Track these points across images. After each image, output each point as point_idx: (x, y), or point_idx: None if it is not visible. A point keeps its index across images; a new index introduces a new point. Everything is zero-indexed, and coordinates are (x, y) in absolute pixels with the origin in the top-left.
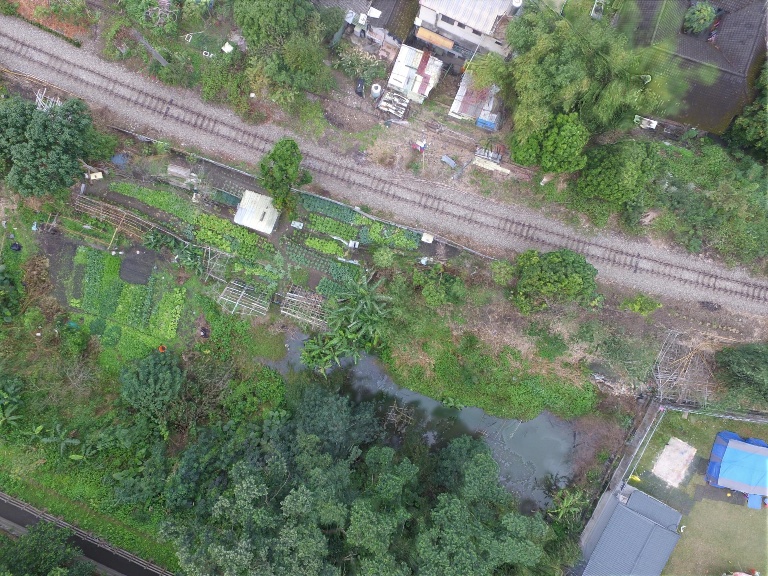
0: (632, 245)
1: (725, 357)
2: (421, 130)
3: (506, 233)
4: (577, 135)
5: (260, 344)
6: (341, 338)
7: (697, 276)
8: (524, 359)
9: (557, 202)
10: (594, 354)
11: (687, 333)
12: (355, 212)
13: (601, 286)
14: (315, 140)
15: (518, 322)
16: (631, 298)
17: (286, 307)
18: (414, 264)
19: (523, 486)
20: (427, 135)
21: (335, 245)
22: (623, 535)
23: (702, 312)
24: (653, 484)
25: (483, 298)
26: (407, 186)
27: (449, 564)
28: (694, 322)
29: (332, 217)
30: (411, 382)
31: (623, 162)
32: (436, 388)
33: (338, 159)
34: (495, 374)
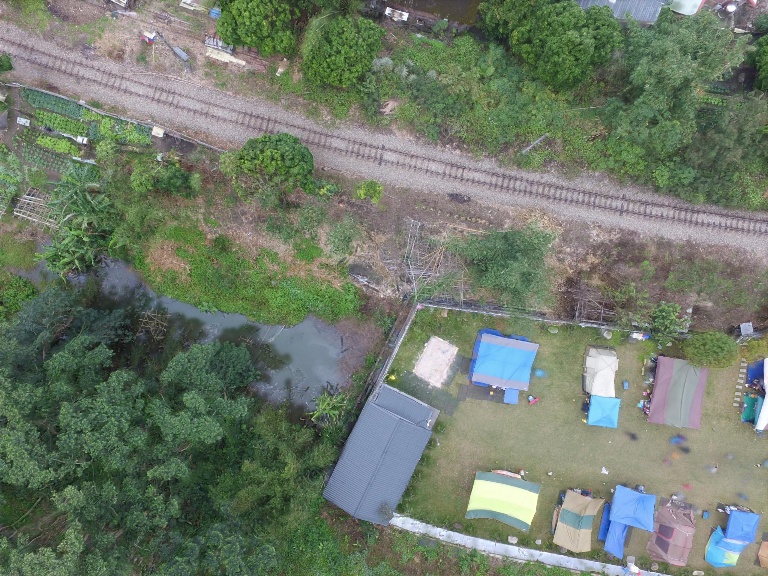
0: (376, 137)
1: (468, 247)
2: (150, 21)
3: (245, 127)
4: (256, 1)
5: (8, 253)
6: (73, 238)
7: (444, 167)
8: (282, 262)
9: (295, 93)
10: (355, 255)
11: (436, 226)
12: (82, 107)
13: (346, 180)
14: (40, 34)
15: (273, 223)
16: None
17: (20, 209)
18: (151, 161)
19: (291, 394)
20: (156, 26)
21: (67, 143)
22: (370, 432)
23: (451, 204)
24: (414, 384)
25: (229, 197)
26: (139, 80)
27: (89, 430)
28: (442, 214)
29: (60, 113)
30: (166, 288)
31: (328, 37)
32: (192, 293)
33: (65, 53)
34: (251, 277)
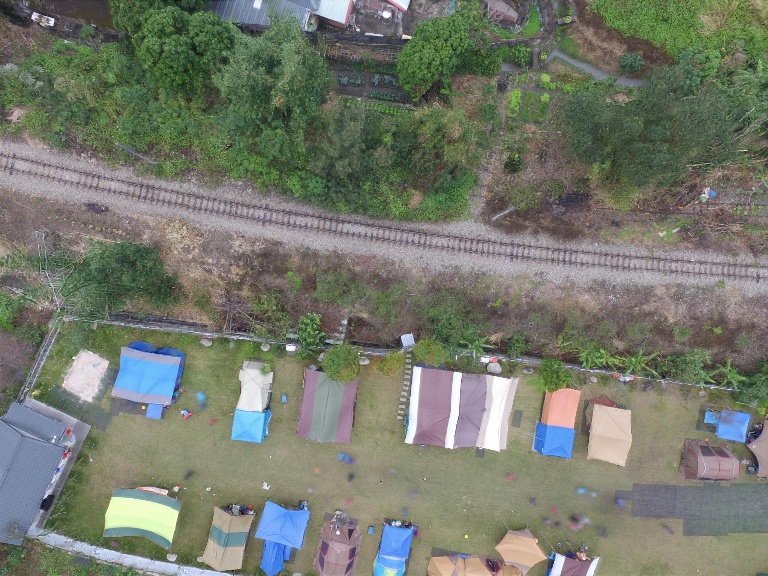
0: (7, 145)
1: None
2: None
3: None
4: None
5: None
6: None
7: (79, 176)
8: None
9: None
10: (7, 266)
11: (72, 237)
12: None
13: None
14: None
15: None
16: (9, 201)
17: None
18: None
19: None
20: None
21: None
22: None
23: (87, 214)
24: (64, 399)
25: None
26: None
27: None
28: (75, 225)
29: None
30: None
31: None
32: None
33: None
34: None
